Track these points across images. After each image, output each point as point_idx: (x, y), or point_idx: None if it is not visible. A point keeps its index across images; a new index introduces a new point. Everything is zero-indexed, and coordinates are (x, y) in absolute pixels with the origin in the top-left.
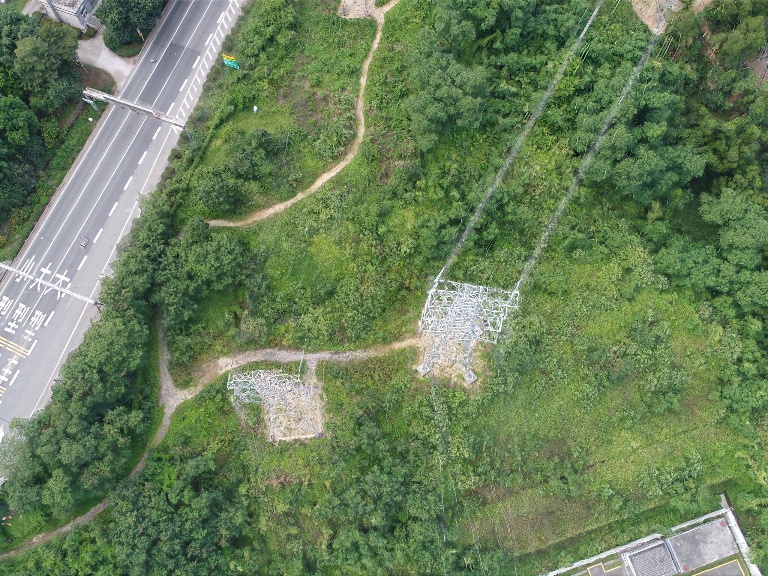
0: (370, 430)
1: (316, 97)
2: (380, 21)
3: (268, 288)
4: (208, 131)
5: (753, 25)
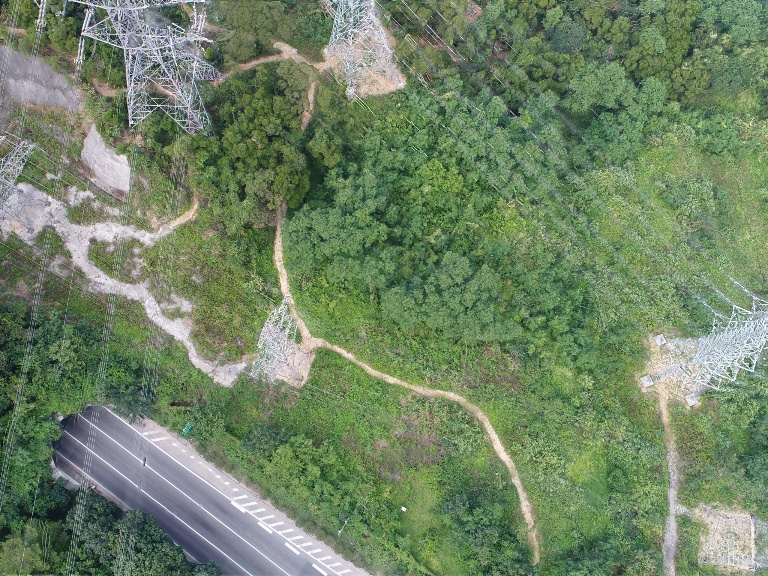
0: (759, 466)
1: (401, 437)
2: (320, 344)
3: (604, 539)
4: (417, 572)
5: (455, 3)
